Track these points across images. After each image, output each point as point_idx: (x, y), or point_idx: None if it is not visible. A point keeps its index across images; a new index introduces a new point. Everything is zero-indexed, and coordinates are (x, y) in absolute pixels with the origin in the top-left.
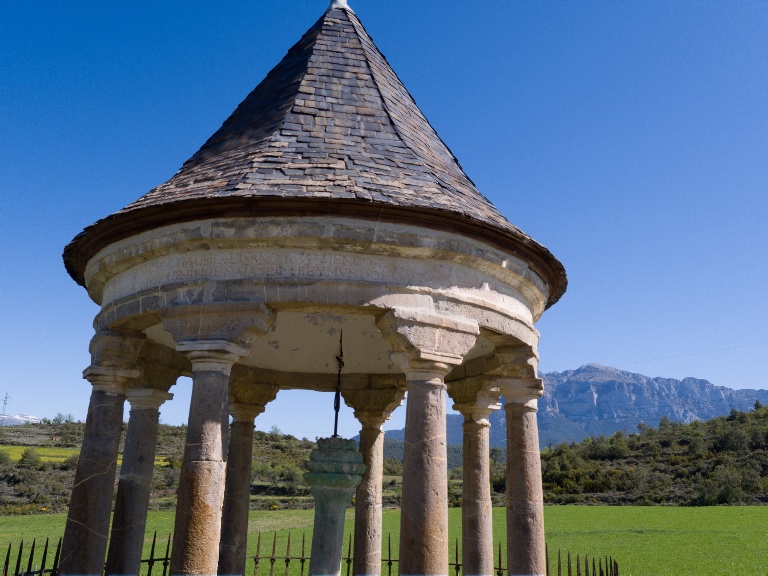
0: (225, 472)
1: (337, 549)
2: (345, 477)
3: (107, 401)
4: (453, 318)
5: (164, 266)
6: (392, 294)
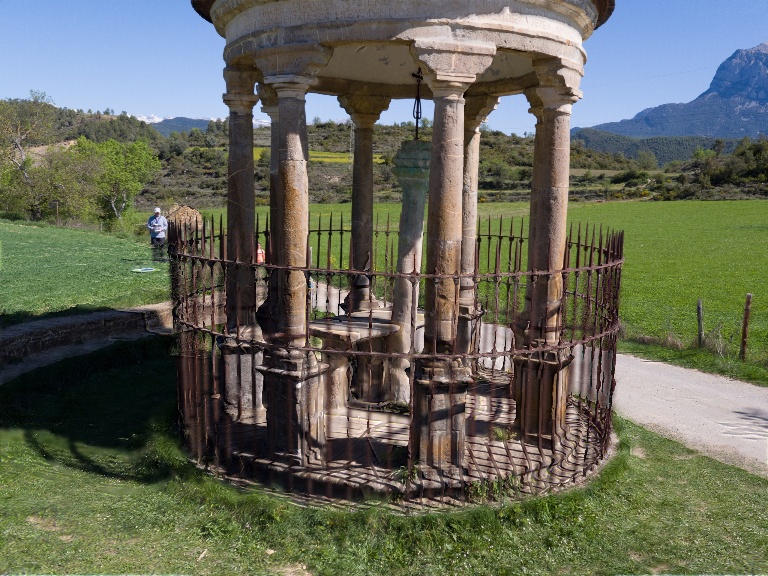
0: None
1: (418, 222)
2: (420, 170)
3: (239, 119)
4: (469, 43)
5: (252, 16)
6: (415, 28)
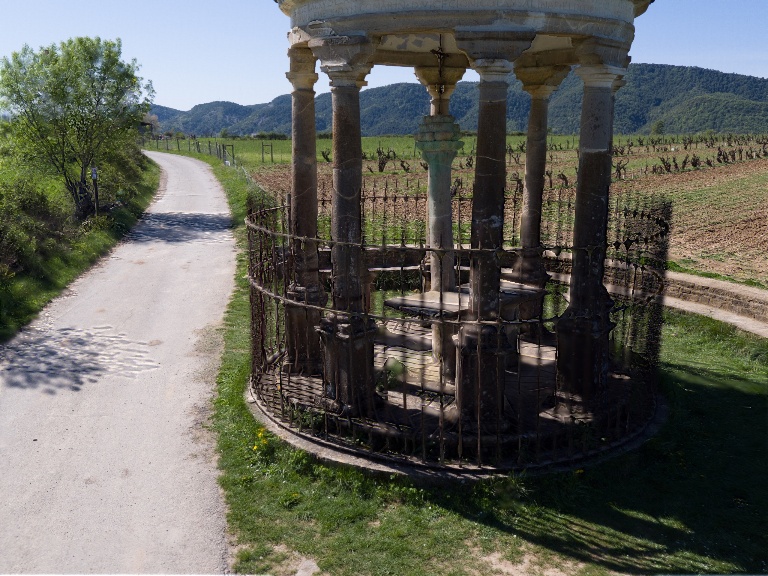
0: (526, 145)
1: None
2: None
3: None
4: None
5: None
6: None
